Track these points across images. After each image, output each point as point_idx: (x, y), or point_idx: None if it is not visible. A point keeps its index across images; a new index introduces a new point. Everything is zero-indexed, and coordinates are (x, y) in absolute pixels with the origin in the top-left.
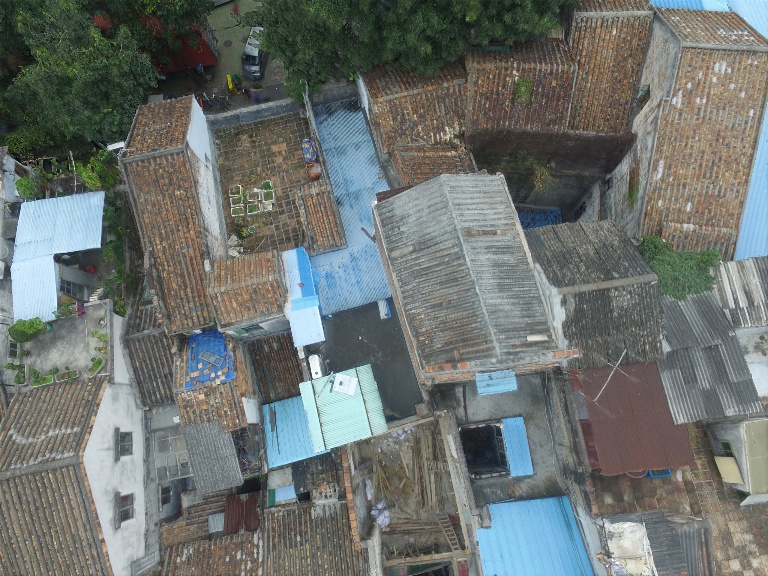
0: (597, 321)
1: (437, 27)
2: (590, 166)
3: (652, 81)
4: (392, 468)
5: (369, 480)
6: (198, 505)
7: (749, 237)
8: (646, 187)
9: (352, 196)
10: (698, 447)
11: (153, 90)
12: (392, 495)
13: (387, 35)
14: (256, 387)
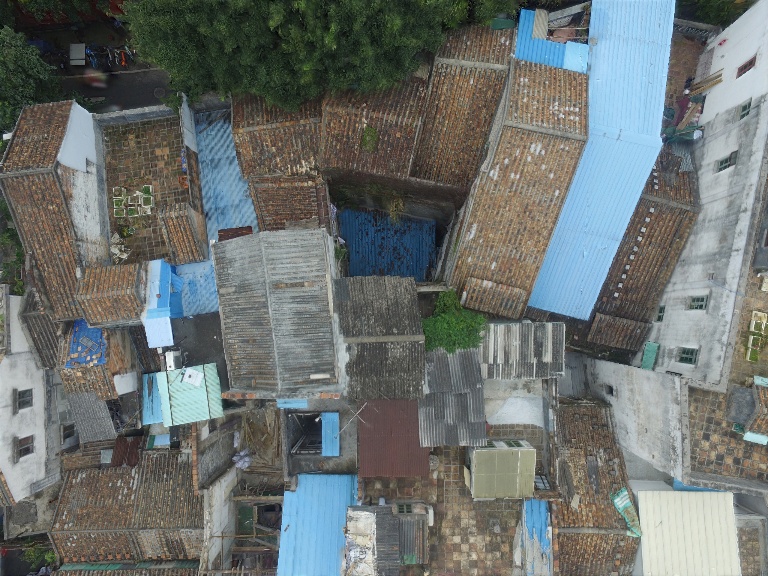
0: (374, 365)
1: (278, 82)
2: (443, 200)
3: (491, 141)
4: (257, 425)
5: (237, 432)
6: (93, 442)
7: (560, 286)
8: (459, 245)
9: (219, 211)
10: (456, 456)
11: (76, 36)
12: (254, 445)
13: (243, 73)
14: (137, 361)
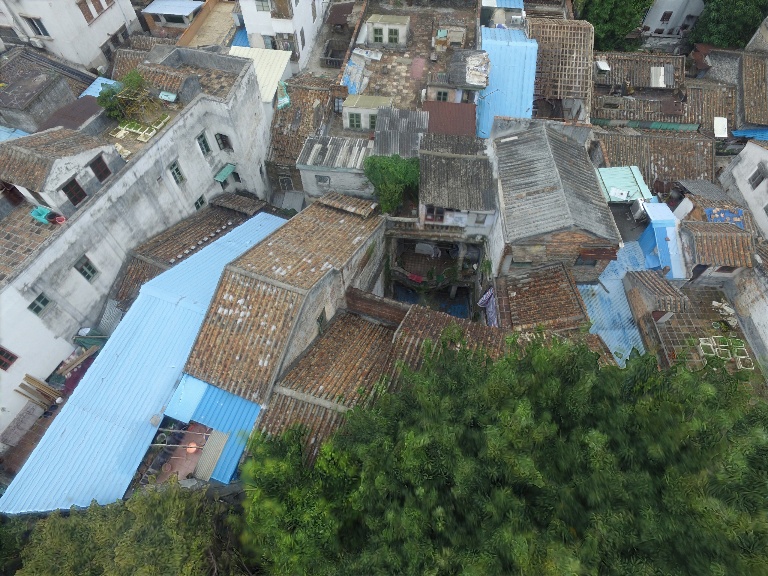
0: None
1: None
2: None
3: None
4: None
5: None
6: None
7: None
8: None
9: (619, 325)
10: None
11: None
12: None
13: None
14: None
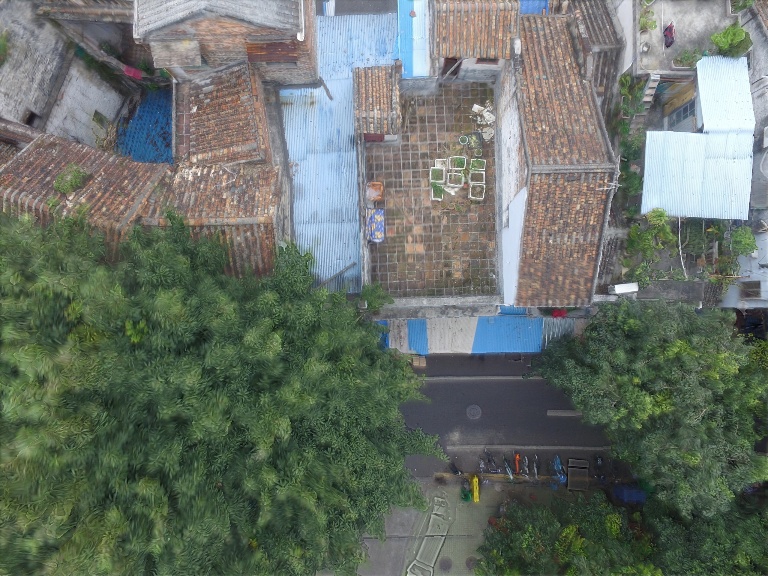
0: None
1: None
2: None
3: None
4: None
5: None
6: None
7: None
8: None
9: (335, 146)
10: None
11: None
12: None
13: None
14: None
